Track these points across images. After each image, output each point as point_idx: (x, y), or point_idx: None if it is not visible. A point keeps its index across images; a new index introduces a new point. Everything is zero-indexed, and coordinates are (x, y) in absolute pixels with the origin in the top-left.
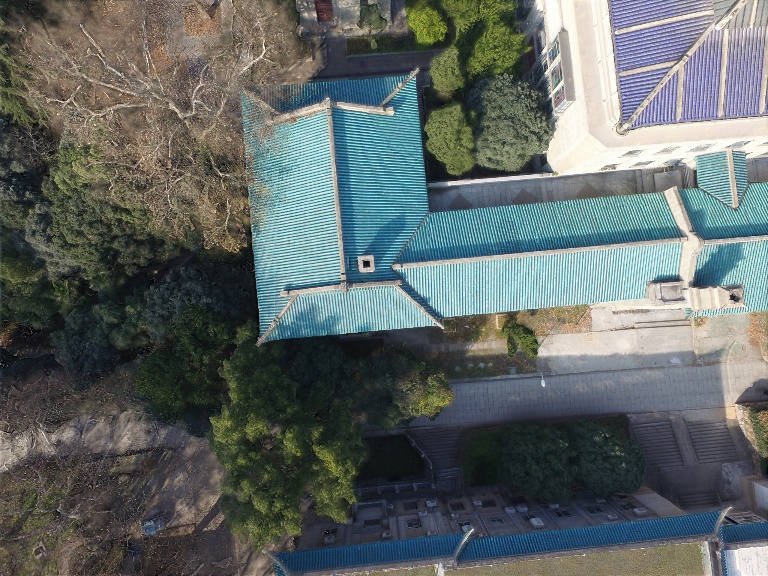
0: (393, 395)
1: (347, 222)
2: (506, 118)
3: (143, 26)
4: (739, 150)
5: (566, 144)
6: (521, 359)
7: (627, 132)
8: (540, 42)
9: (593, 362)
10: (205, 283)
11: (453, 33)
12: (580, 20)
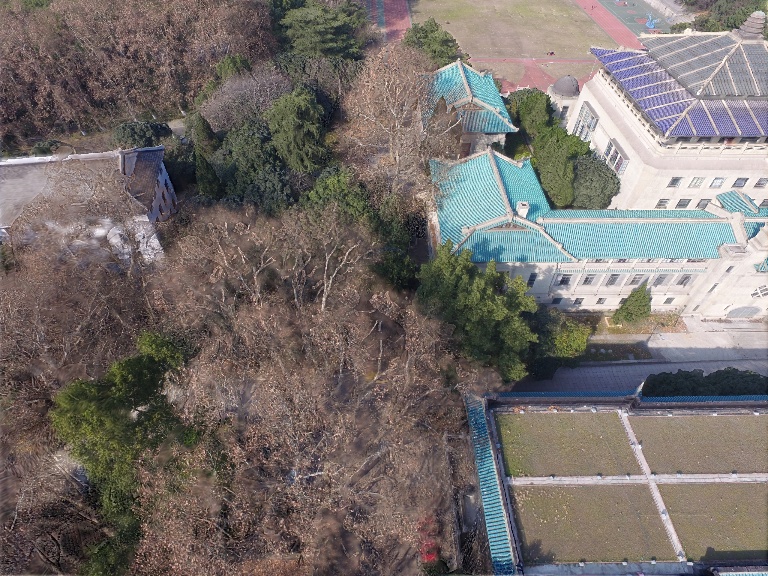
0: (542, 320)
1: (506, 193)
2: None
3: None
4: (743, 193)
5: (630, 186)
6: (636, 348)
7: (669, 139)
8: None
9: (700, 353)
10: None
11: None
12: (621, 129)
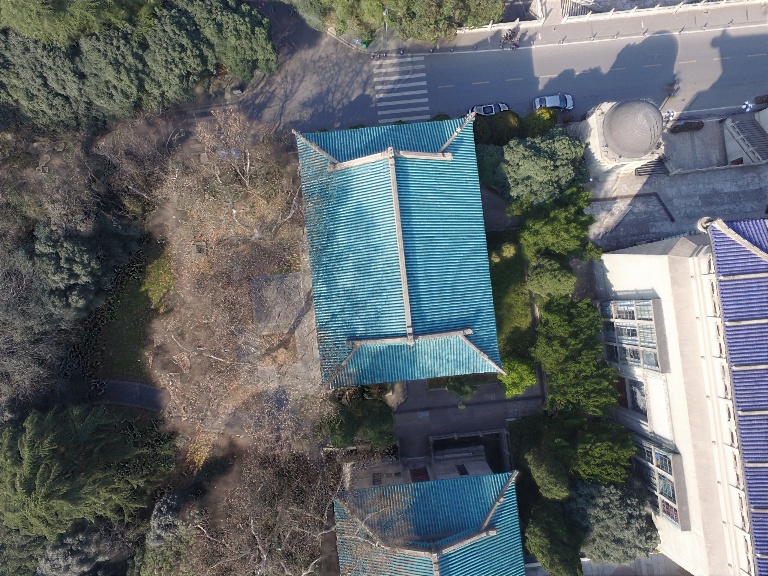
0: None
1: None
2: (615, 539)
3: (260, 570)
4: None
5: (674, 549)
6: None
7: None
8: (635, 397)
9: None
10: None
11: (537, 363)
12: (700, 464)
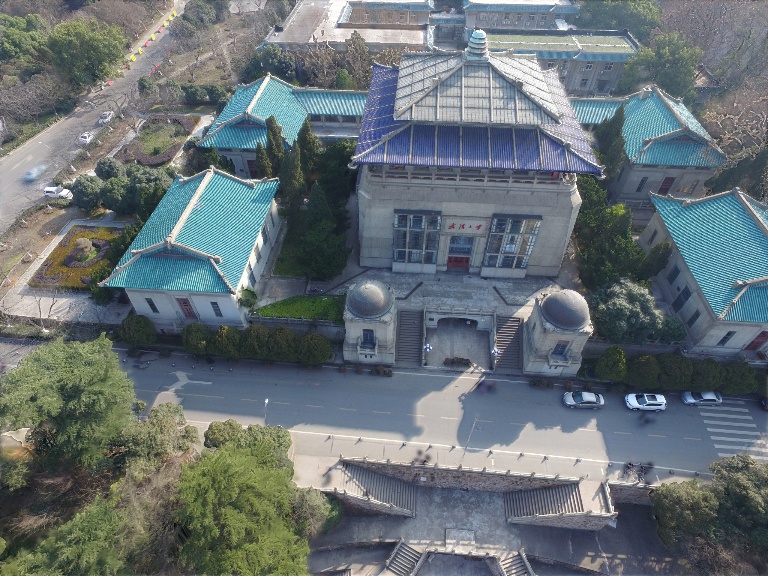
0: None
1: None
2: None
3: None
4: None
5: None
6: None
7: None
8: None
9: None
10: (715, 135)
11: None
12: None
